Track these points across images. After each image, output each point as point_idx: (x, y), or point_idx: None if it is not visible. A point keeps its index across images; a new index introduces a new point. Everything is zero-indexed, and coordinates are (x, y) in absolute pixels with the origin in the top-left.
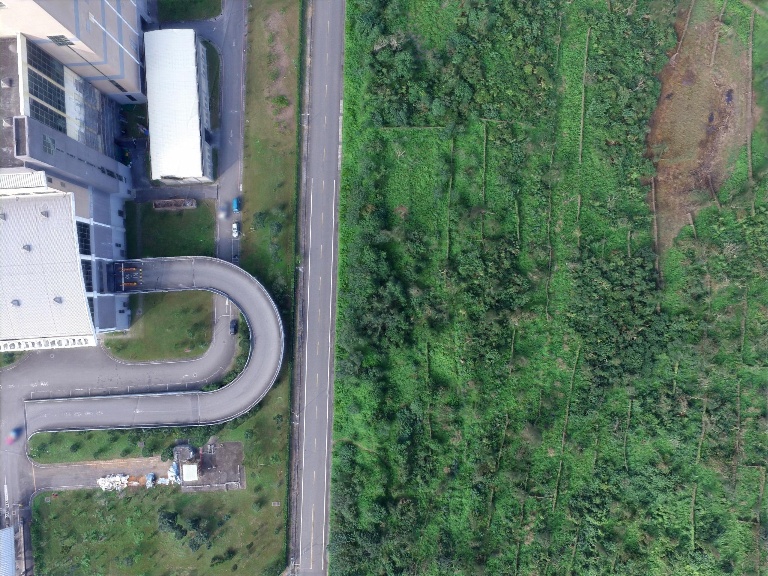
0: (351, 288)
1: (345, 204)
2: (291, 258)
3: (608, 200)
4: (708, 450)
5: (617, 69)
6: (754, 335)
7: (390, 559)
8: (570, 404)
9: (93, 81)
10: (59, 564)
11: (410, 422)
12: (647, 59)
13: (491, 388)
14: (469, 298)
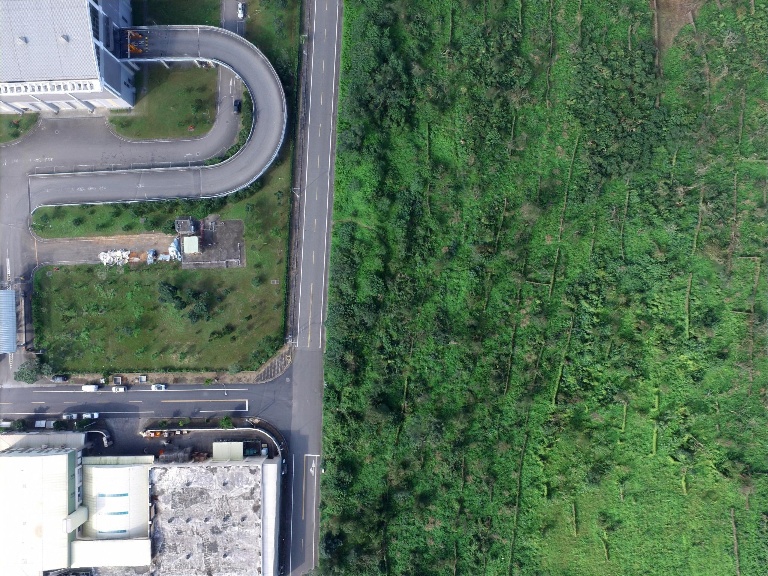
0: None
1: None
2: (295, 40)
3: None
4: (704, 239)
5: None
6: (752, 129)
7: (387, 332)
8: (568, 192)
9: None
10: (59, 337)
11: (409, 202)
12: None
13: (490, 170)
14: (470, 75)
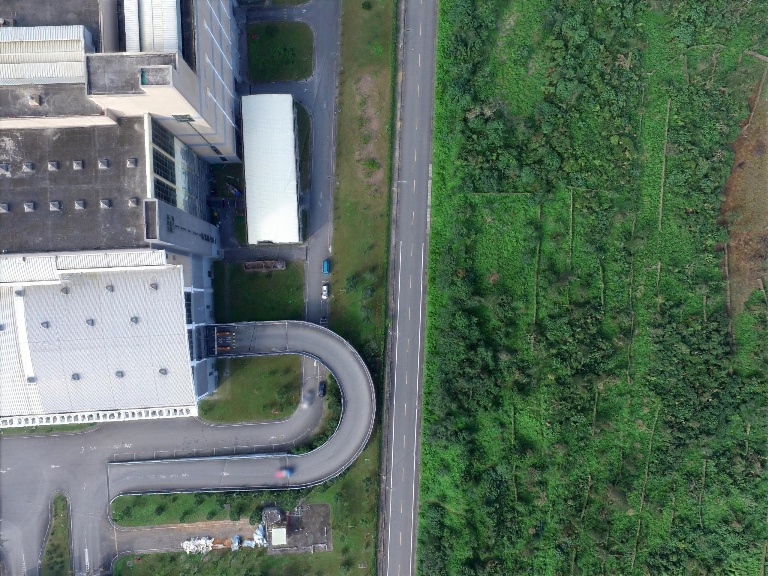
0: (439, 350)
1: (434, 267)
2: (380, 320)
3: (686, 266)
4: None
5: (696, 140)
6: None
7: None
8: (649, 464)
9: (194, 147)
10: None
11: (496, 484)
12: (722, 130)
13: (575, 450)
14: (558, 363)
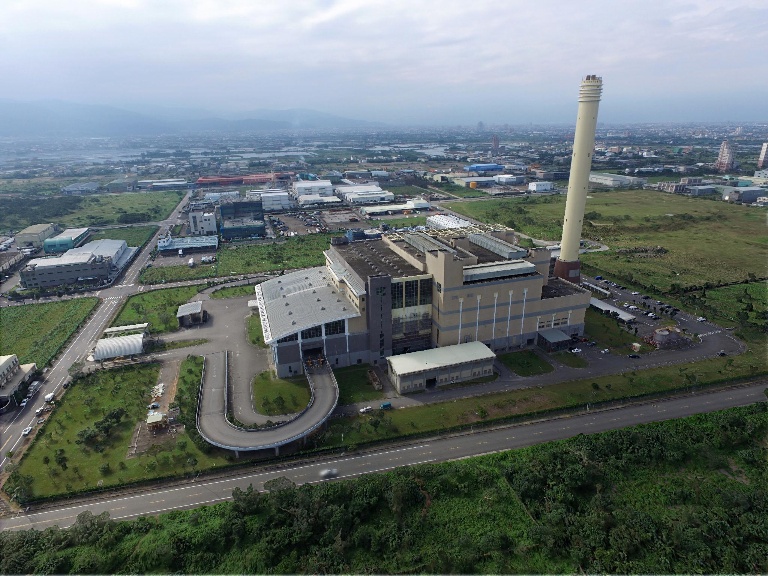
0: None
1: None
2: None
3: None
4: None
5: None
6: None
7: None
8: None
9: None
10: None
11: None
12: None
13: None
14: None
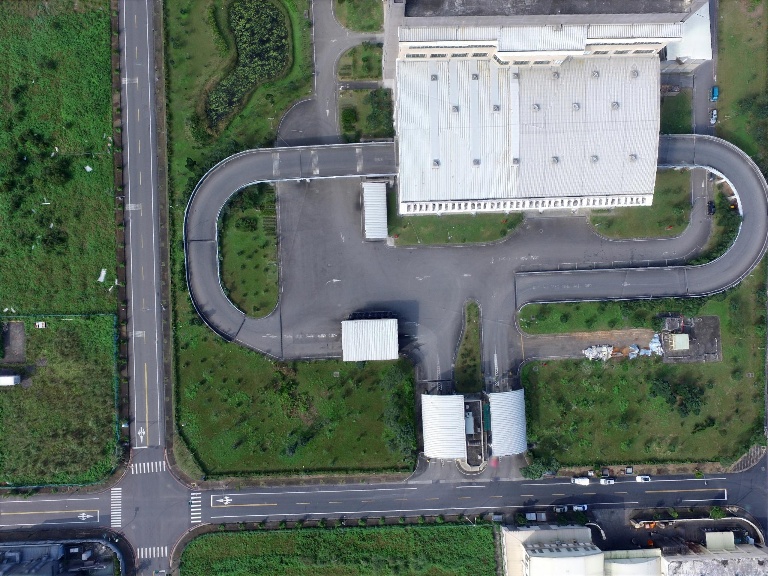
0: None
1: None
2: None
3: None
4: None
5: None
6: None
7: None
8: None
9: None
10: (547, 431)
11: None
12: None
13: None
14: None
